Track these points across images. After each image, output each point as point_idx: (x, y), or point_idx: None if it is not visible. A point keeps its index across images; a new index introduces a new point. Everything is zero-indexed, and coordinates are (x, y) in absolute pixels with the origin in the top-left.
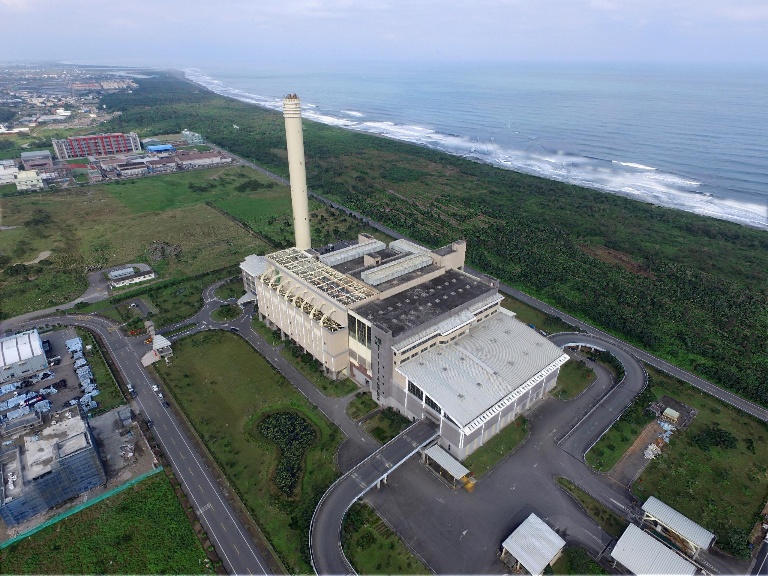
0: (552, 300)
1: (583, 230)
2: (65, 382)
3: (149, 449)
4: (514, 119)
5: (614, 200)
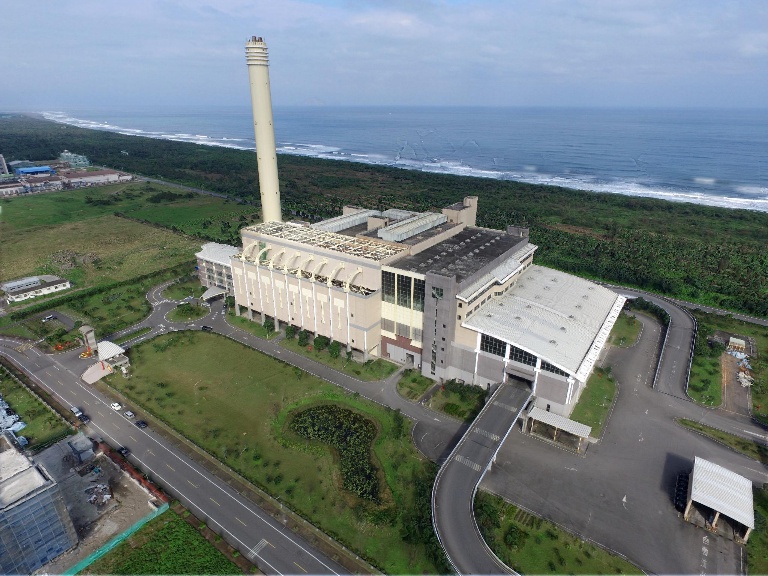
0: (551, 265)
1: (538, 211)
2: None
3: (135, 484)
4: (435, 125)
5: (549, 189)
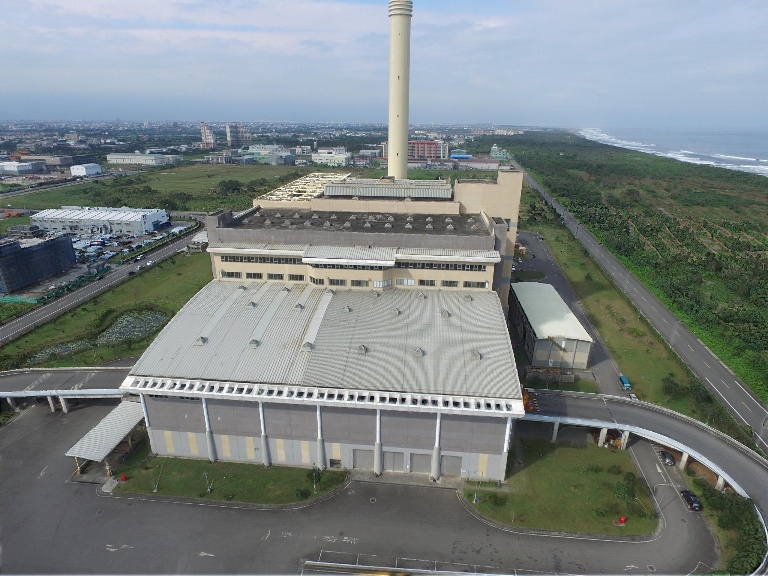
0: (758, 372)
1: None
2: (129, 243)
3: None
4: None
5: None
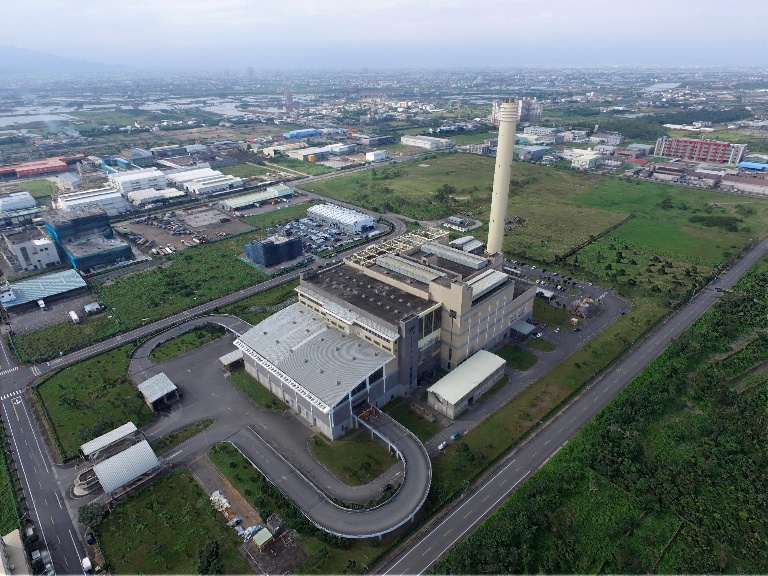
0: None
1: None
2: (340, 240)
3: None
4: None
5: None
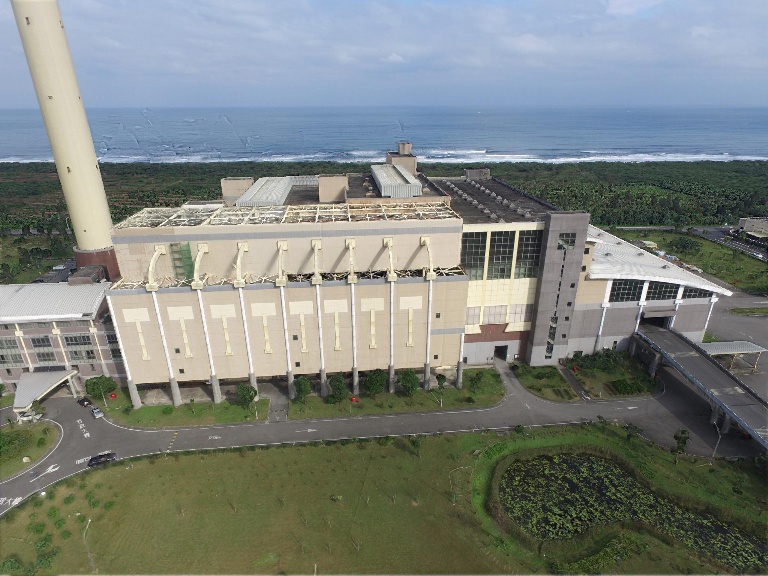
0: None
1: None
2: None
3: None
4: (147, 106)
5: (319, 164)
